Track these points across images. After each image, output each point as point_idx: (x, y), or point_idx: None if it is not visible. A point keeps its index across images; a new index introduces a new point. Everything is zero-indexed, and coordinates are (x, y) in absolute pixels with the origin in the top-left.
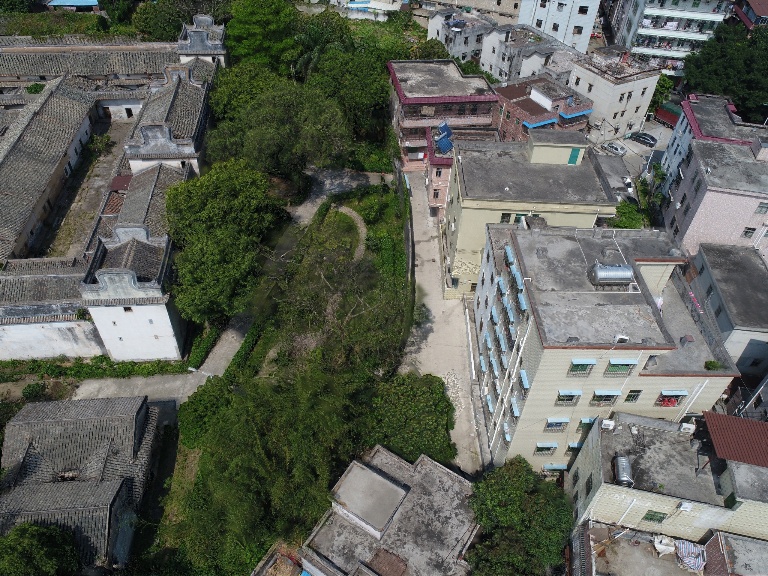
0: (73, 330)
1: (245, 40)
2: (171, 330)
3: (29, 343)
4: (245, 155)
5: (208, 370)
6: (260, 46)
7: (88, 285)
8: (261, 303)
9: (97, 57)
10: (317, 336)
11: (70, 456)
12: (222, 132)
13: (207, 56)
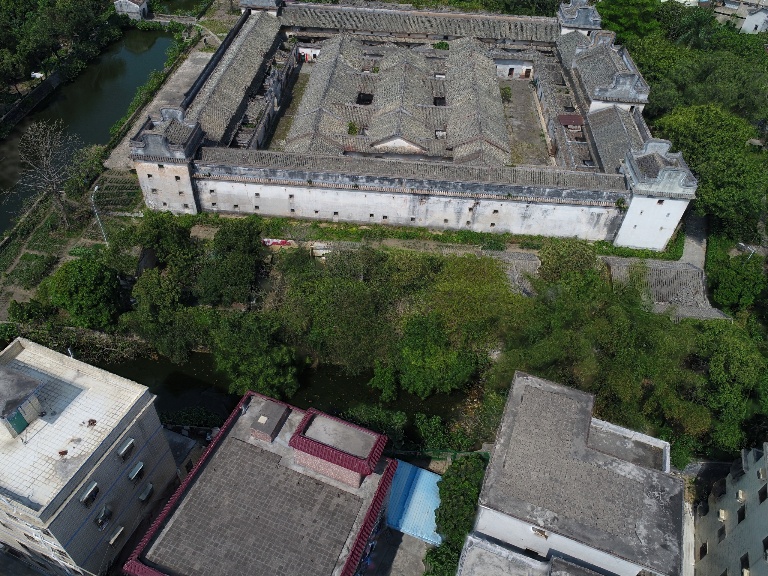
0: (601, 216)
1: (621, 19)
2: (676, 224)
3: (561, 223)
4: (693, 104)
5: (687, 261)
6: (632, 25)
7: (648, 178)
8: (701, 221)
9: (492, 24)
10: (761, 249)
11: (661, 292)
12: (664, 86)
13: (585, 30)
